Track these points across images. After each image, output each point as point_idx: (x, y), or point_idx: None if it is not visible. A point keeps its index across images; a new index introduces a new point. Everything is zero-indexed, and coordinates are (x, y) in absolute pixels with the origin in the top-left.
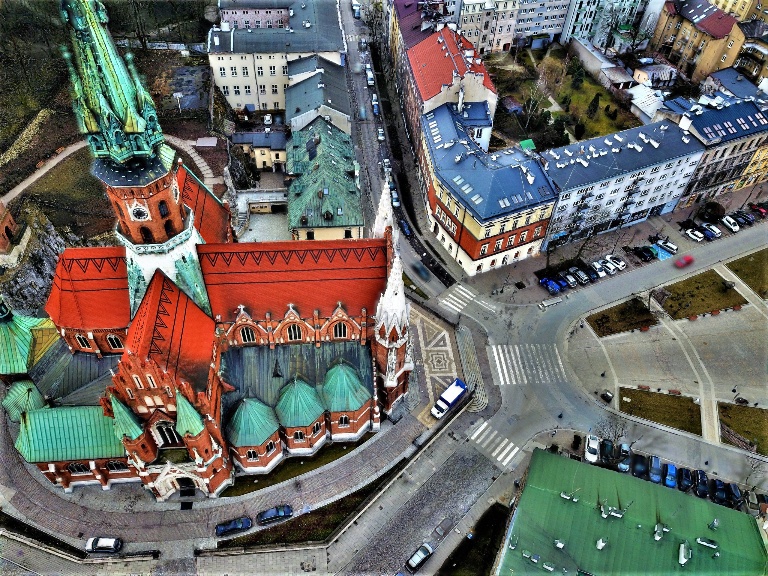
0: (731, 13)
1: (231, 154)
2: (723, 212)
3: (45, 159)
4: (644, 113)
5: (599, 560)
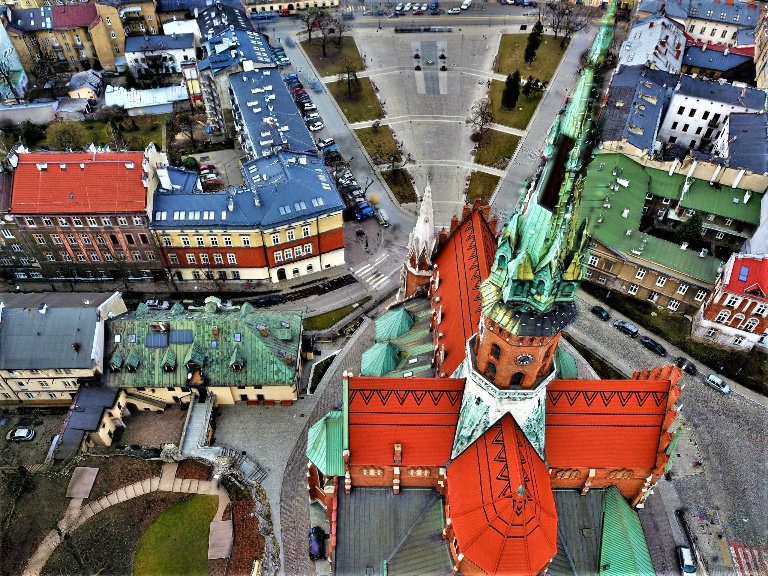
0: (65, 3)
1: None
2: None
3: None
4: (148, 106)
5: (632, 220)
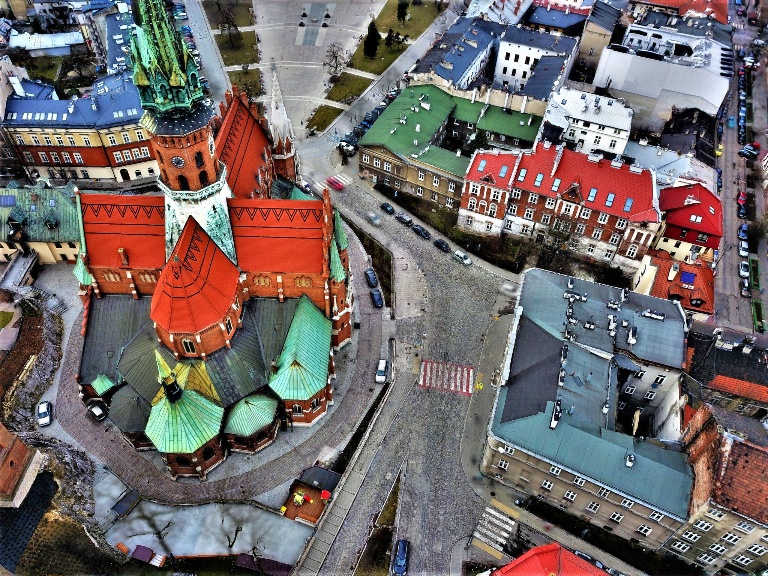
0: None
1: None
2: None
3: None
4: (47, 48)
5: (424, 134)
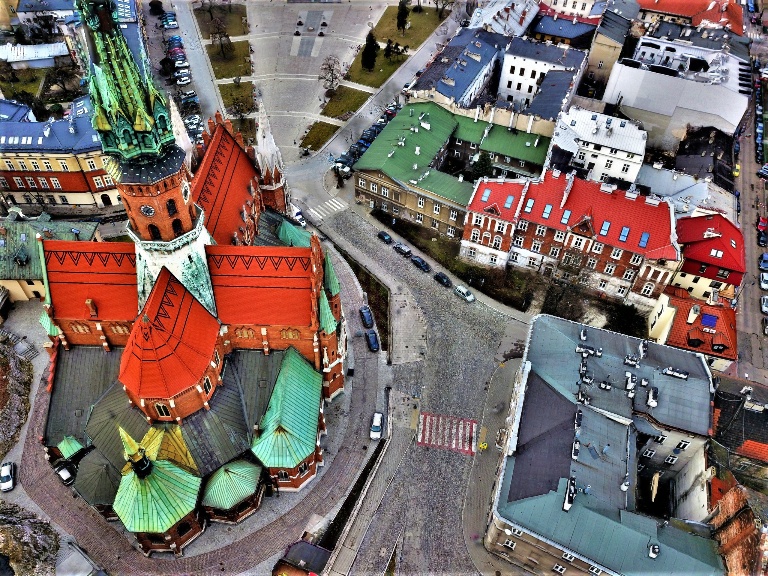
0: None
1: None
2: (174, 60)
3: None
4: (30, 60)
5: (424, 157)
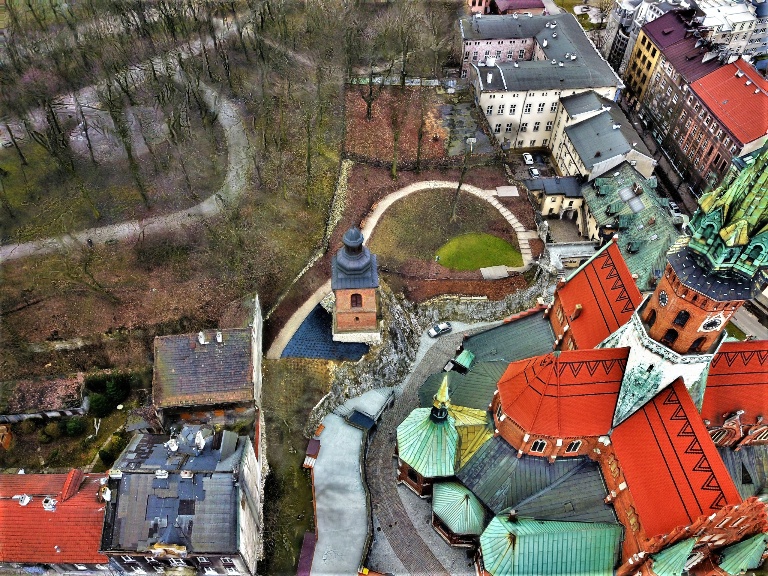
0: None
1: (532, 204)
2: None
3: (363, 217)
4: None
5: None
